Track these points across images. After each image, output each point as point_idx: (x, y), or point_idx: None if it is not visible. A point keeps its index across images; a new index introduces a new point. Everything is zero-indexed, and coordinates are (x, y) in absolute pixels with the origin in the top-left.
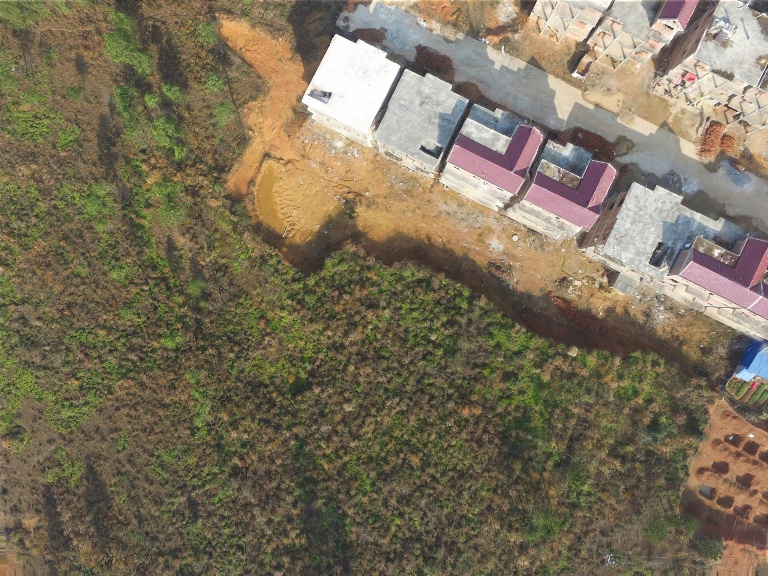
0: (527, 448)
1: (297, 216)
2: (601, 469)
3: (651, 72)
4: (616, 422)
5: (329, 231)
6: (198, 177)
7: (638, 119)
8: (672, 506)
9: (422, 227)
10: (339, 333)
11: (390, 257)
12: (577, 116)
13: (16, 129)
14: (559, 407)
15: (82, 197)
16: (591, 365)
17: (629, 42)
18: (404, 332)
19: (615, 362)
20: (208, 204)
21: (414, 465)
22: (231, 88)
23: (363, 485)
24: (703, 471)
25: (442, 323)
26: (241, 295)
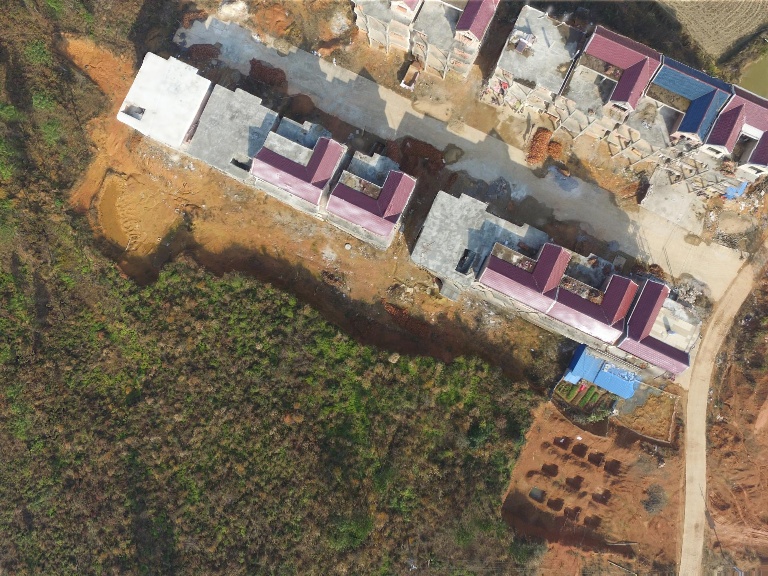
0: (347, 455)
1: (139, 229)
2: (420, 474)
3: (479, 81)
4: (438, 427)
5: (170, 243)
6: (41, 193)
7: (467, 127)
8: (493, 510)
9: (257, 238)
10: (170, 344)
11: (225, 268)
12: (407, 125)
13: None
14: (380, 414)
15: None
16: (414, 371)
17: (439, 53)
18: (233, 342)
19: (437, 368)
20: (50, 219)
21: (240, 474)
22: (75, 105)
23: (192, 494)
24: (532, 474)
25: (268, 333)
26: (82, 308)
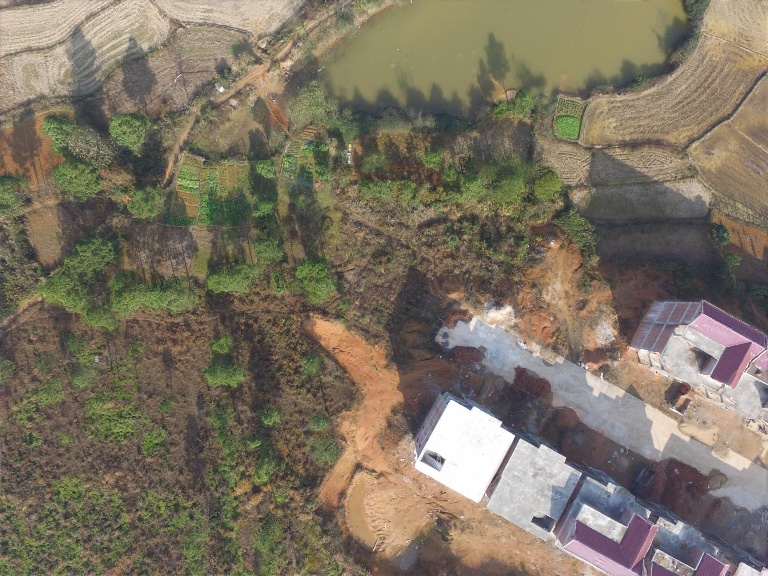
0: None
1: (388, 530)
2: None
3: None
4: None
5: (420, 547)
6: (289, 490)
7: (732, 453)
8: None
9: (516, 554)
10: None
11: None
12: (673, 447)
13: (99, 429)
14: None
15: (168, 508)
16: None
17: None
18: None
19: None
20: (299, 519)
21: None
22: (324, 394)
23: None
24: None
25: None
26: None
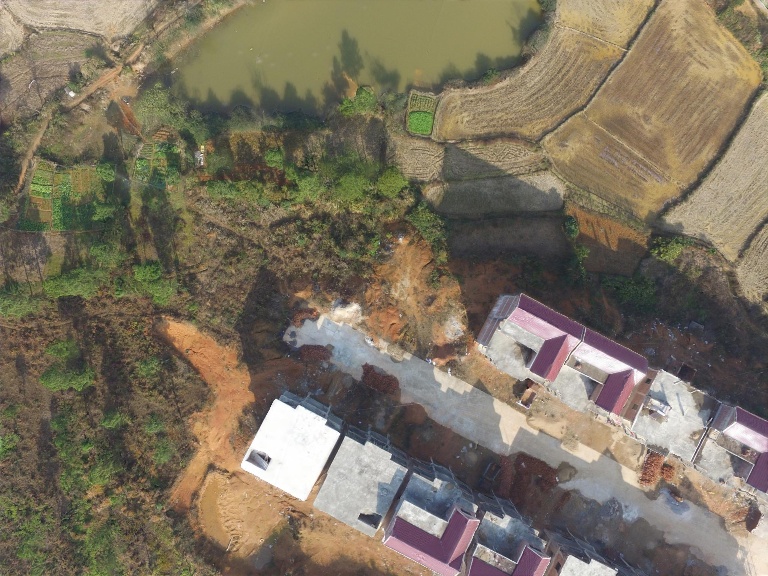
0: None
1: (241, 529)
2: None
3: None
4: None
5: (273, 546)
6: (140, 492)
7: (581, 446)
8: None
9: (366, 551)
10: None
11: None
12: (521, 441)
13: None
14: None
15: (19, 512)
16: None
17: None
18: None
19: None
20: None
21: None
22: (176, 395)
23: None
24: None
25: None
26: None
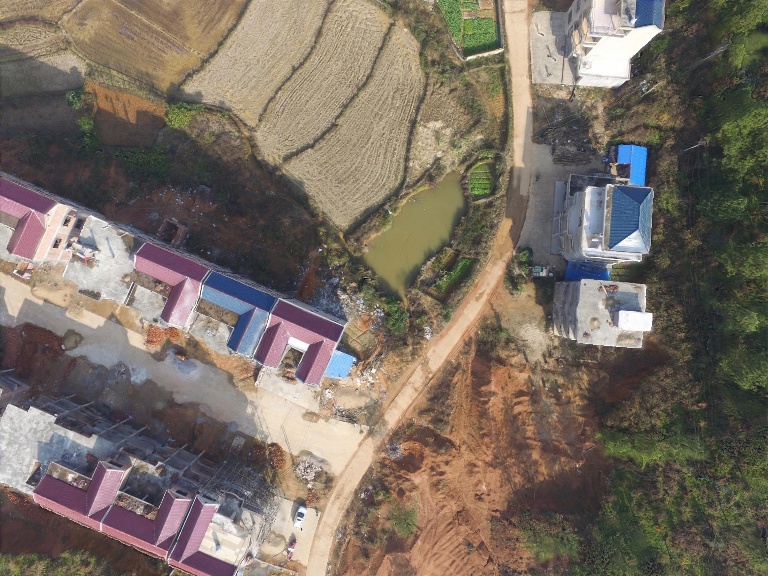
0: None
1: None
2: None
3: None
4: None
5: None
6: None
7: (86, 312)
8: None
9: None
10: None
11: None
12: (27, 312)
13: None
14: None
15: None
16: (15, 571)
17: None
18: None
19: (38, 567)
20: None
21: None
22: None
23: None
24: None
25: None
26: None
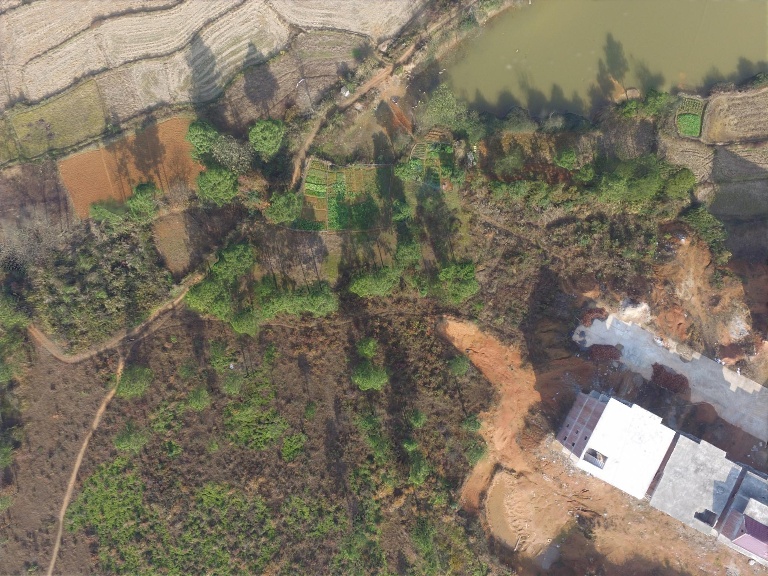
0: None
1: (529, 529)
2: None
3: None
4: None
5: (561, 545)
6: (432, 492)
7: None
8: None
9: (660, 550)
10: None
11: None
12: None
13: (239, 435)
14: None
15: (313, 513)
16: None
17: None
18: None
19: None
20: None
21: None
22: (461, 395)
23: None
24: None
25: None
26: None
